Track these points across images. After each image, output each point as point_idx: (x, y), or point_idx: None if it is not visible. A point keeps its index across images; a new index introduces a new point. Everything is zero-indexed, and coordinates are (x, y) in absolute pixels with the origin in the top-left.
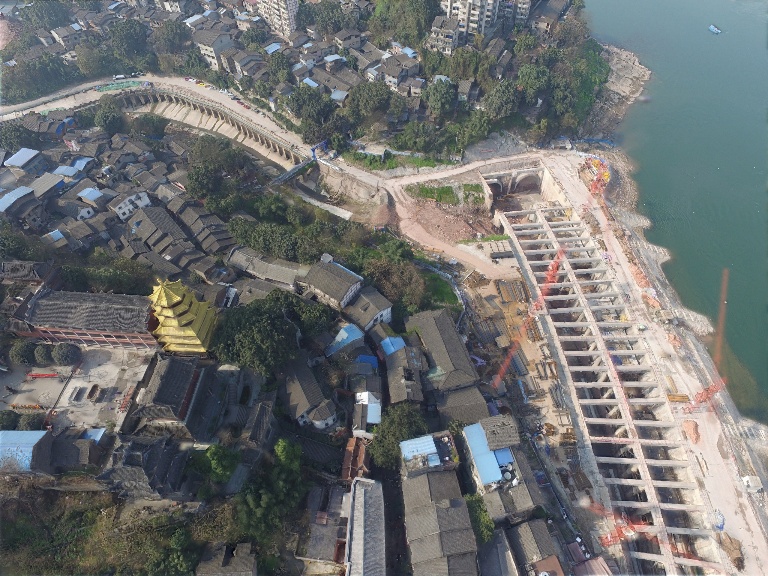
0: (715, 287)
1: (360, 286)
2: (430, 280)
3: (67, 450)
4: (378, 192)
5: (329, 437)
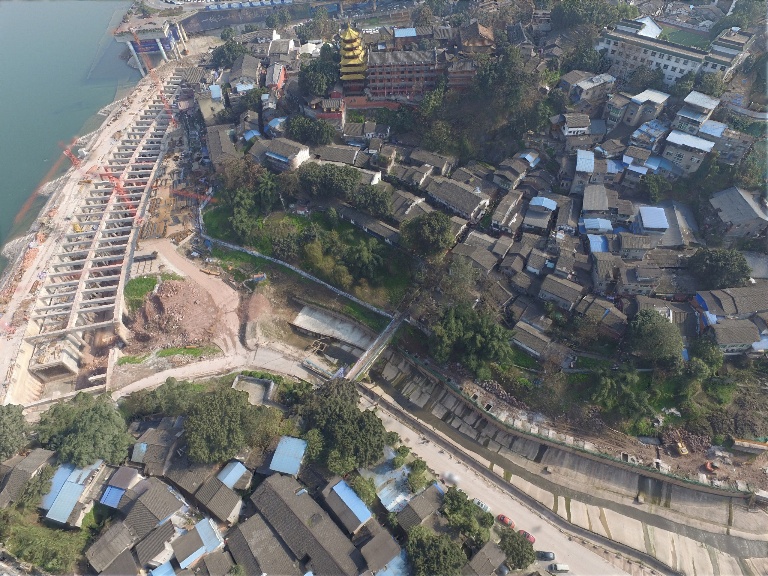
0: None
1: None
2: (221, 222)
3: None
4: None
5: None
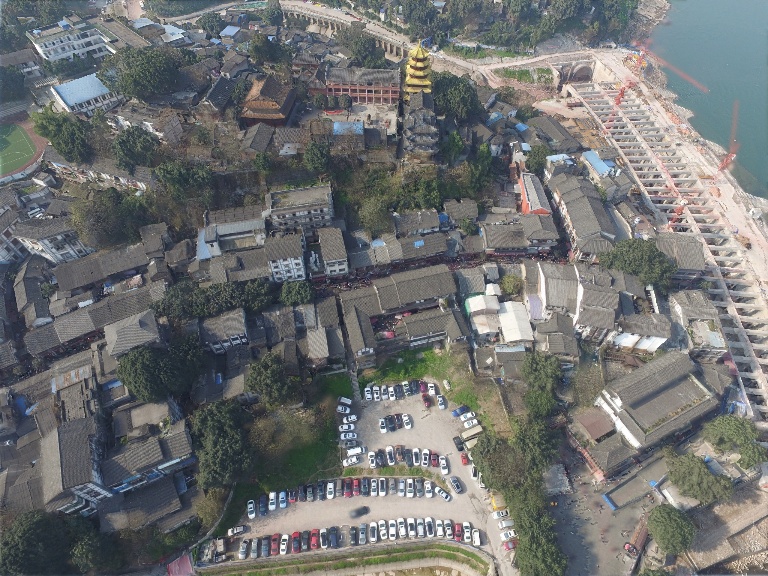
0: (727, 130)
1: (494, 99)
2: None
3: (373, 132)
4: (474, 73)
5: (500, 159)
